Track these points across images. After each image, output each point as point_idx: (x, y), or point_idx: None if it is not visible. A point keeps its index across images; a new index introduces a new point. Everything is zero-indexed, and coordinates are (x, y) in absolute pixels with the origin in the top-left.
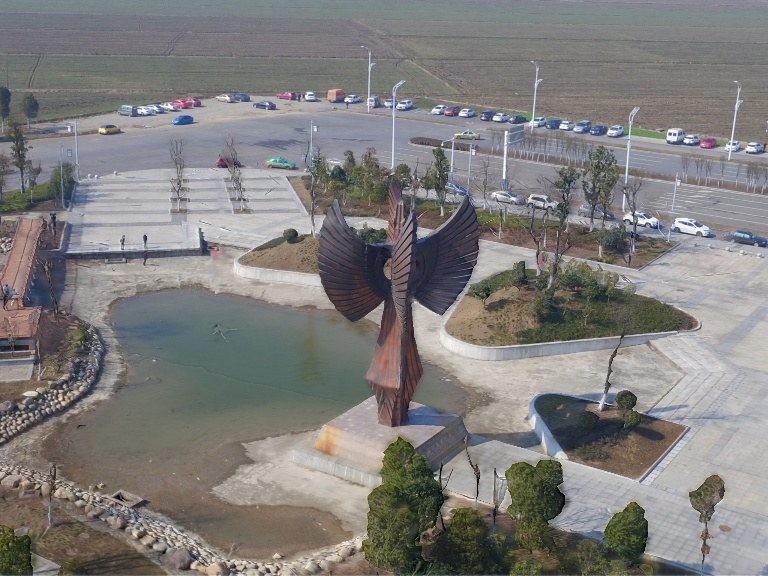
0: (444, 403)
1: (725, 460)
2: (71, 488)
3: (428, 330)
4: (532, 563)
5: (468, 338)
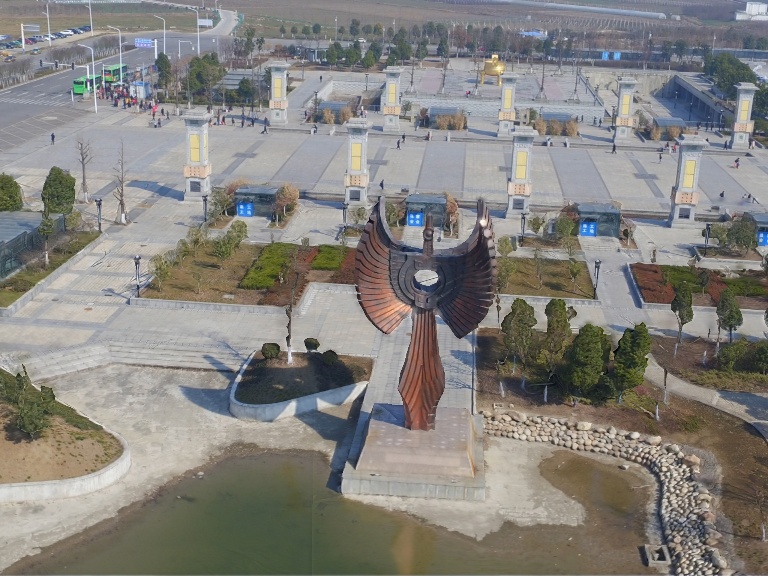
0: (267, 465)
1: (305, 338)
2: (698, 574)
3: (39, 512)
4: (537, 370)
5: (104, 458)
